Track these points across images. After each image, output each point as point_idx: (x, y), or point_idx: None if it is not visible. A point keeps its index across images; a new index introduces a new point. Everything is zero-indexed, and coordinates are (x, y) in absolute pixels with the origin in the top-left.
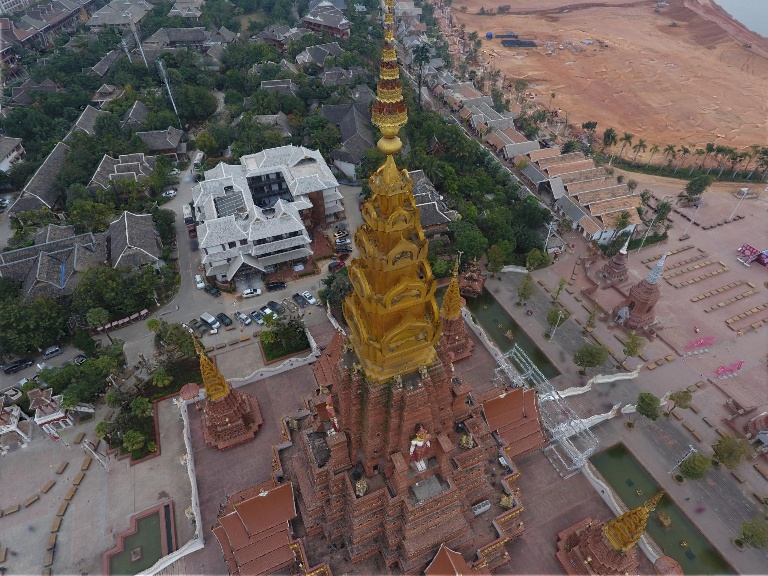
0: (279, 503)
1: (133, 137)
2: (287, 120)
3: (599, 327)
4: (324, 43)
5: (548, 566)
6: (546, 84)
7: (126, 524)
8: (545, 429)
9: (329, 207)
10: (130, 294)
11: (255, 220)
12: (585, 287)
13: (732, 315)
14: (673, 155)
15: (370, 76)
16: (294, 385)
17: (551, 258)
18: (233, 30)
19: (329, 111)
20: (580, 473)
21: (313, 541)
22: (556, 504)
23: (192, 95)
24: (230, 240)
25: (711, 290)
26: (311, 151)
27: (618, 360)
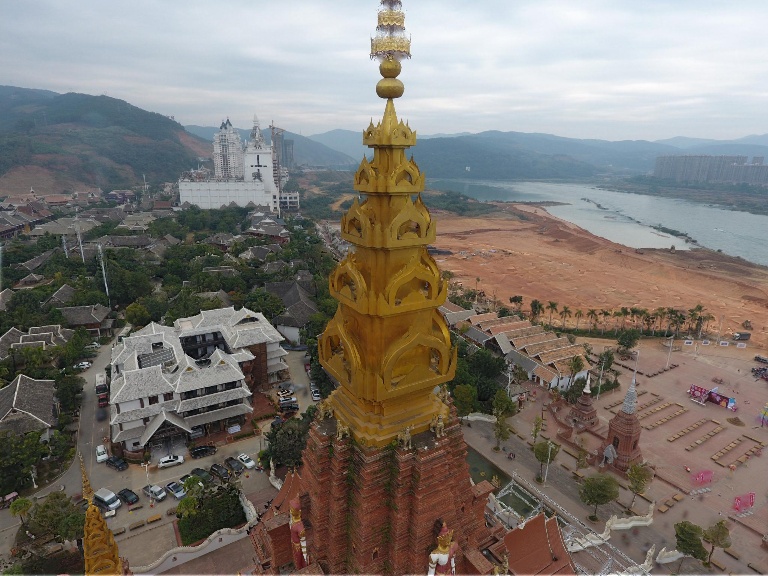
0: None
1: (52, 311)
2: (228, 297)
3: (589, 471)
4: (266, 244)
5: None
6: (468, 278)
7: None
8: None
9: (272, 365)
10: None
11: (186, 369)
12: (560, 430)
13: (714, 451)
14: (596, 319)
15: (311, 264)
16: (222, 570)
17: (516, 406)
18: (178, 237)
19: (272, 287)
20: None
21: None
22: None
23: (128, 278)
24: (152, 393)
25: (682, 429)
26: (254, 312)
27: (624, 505)
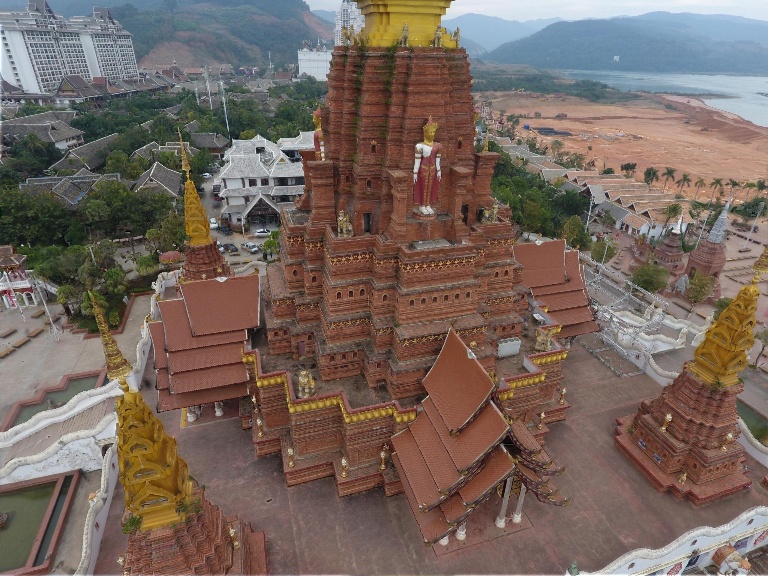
0: (239, 301)
1: (183, 132)
2: None
3: None
4: None
5: (604, 454)
6: None
7: (55, 383)
8: (594, 312)
9: None
10: (139, 212)
11: (280, 160)
12: None
13: None
14: (721, 192)
15: None
16: None
17: None
18: (293, 97)
19: None
20: (643, 374)
21: (275, 359)
22: (612, 397)
23: (245, 117)
24: (251, 175)
25: None
26: None
27: None
